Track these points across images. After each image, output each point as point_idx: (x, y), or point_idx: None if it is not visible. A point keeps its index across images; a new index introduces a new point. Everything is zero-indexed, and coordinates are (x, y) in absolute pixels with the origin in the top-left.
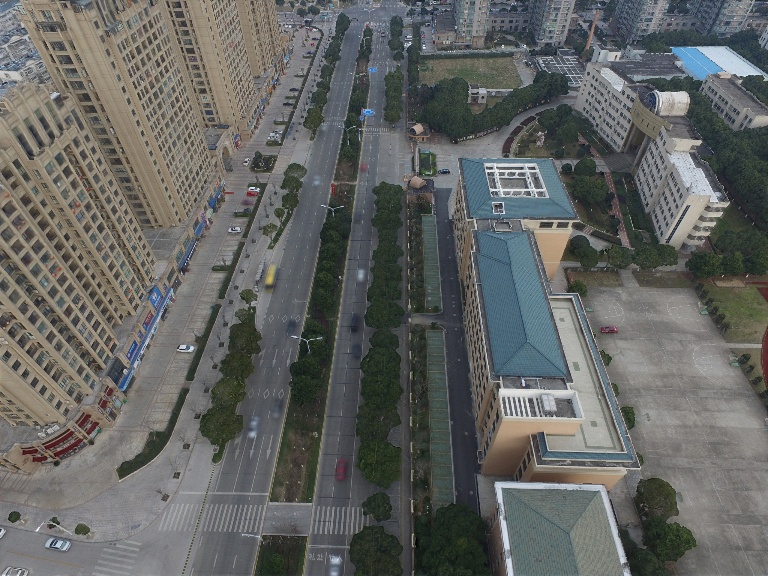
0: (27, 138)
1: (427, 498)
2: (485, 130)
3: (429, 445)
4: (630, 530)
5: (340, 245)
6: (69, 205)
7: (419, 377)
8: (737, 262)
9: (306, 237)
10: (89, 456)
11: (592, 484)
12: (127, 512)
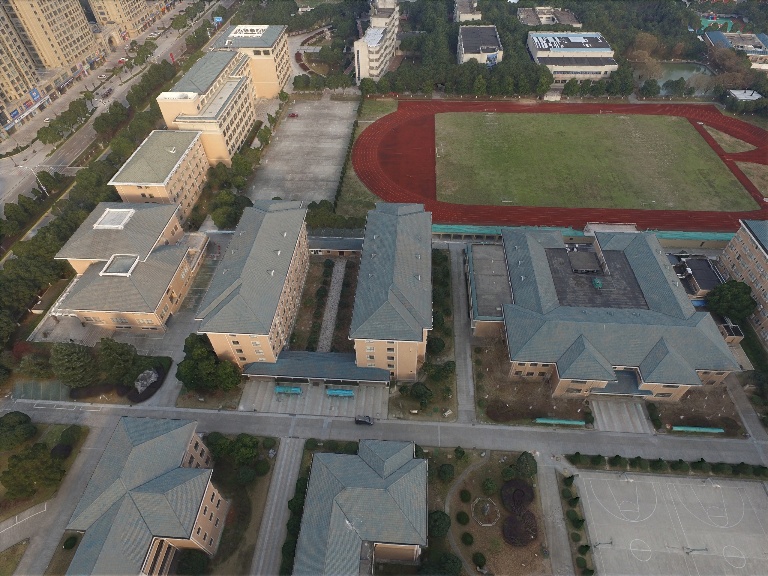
0: None
1: None
2: (296, 31)
3: None
4: None
5: (157, 79)
6: None
7: None
8: (382, 82)
9: None
10: None
11: None
12: None
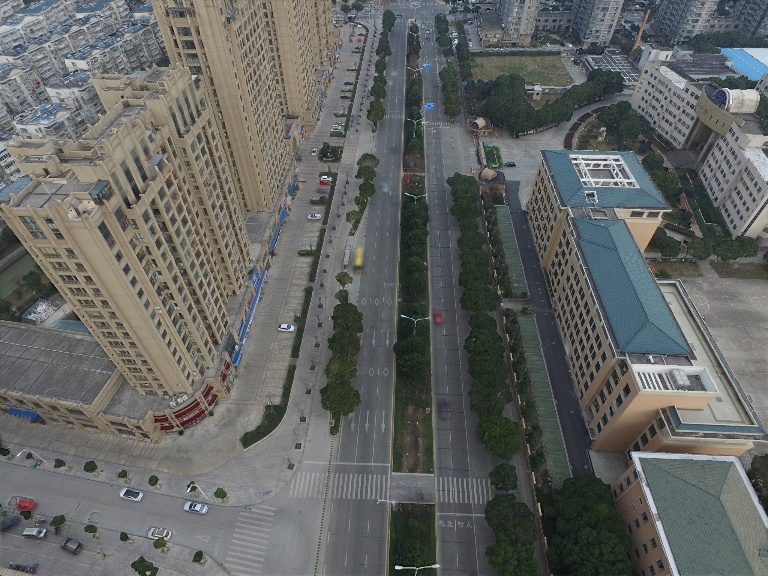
0: (177, 117)
1: (545, 471)
2: (545, 125)
3: (538, 422)
4: None
5: (423, 232)
6: (203, 183)
7: (519, 358)
8: None
9: (384, 225)
10: (210, 427)
11: (725, 455)
12: (256, 479)
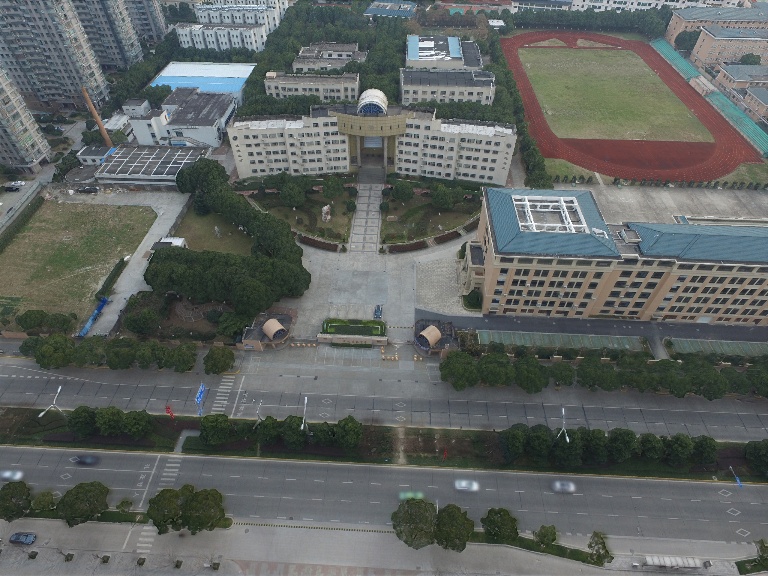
0: None
1: None
2: None
3: None
4: None
5: None
6: None
7: None
8: None
9: (556, 500)
10: None
11: None
12: None
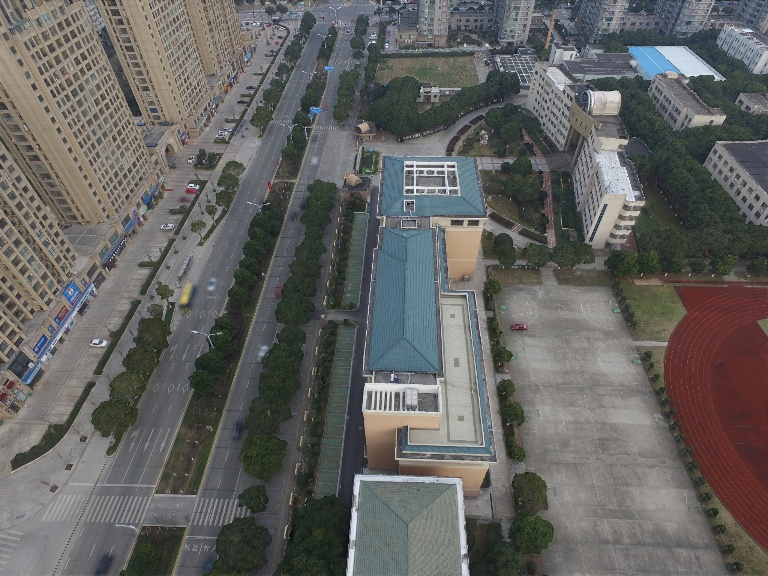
0: None
1: (309, 491)
2: (431, 129)
3: (321, 439)
4: (503, 524)
5: (265, 242)
6: None
7: (322, 372)
8: (652, 261)
9: (237, 234)
10: None
11: (449, 477)
12: (14, 503)
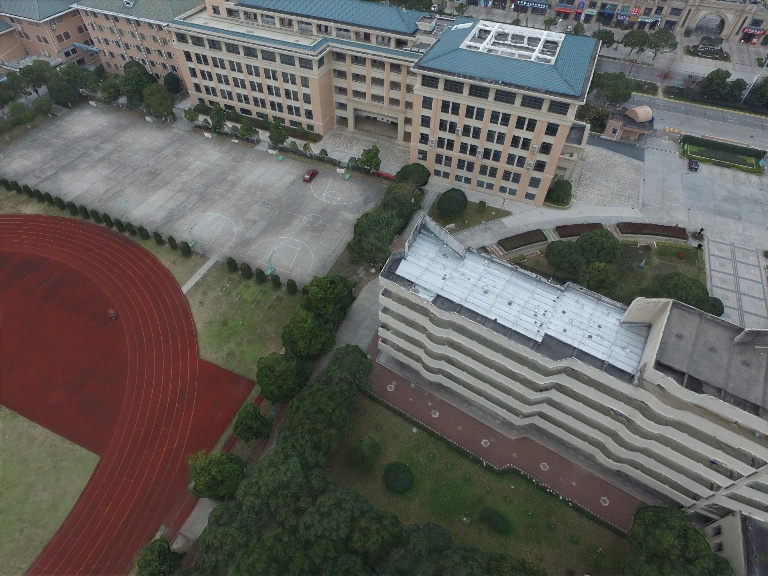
0: None
1: None
2: None
3: None
4: None
5: None
6: None
7: None
8: None
9: None
10: None
11: None
12: None
